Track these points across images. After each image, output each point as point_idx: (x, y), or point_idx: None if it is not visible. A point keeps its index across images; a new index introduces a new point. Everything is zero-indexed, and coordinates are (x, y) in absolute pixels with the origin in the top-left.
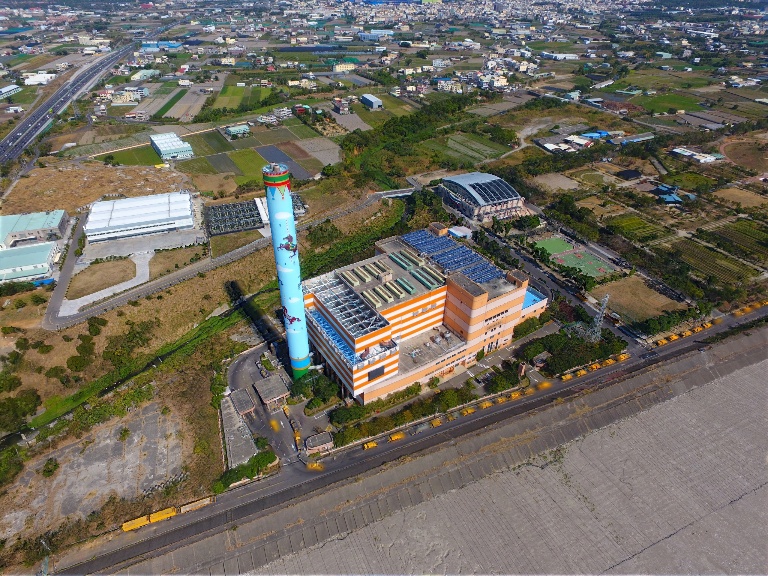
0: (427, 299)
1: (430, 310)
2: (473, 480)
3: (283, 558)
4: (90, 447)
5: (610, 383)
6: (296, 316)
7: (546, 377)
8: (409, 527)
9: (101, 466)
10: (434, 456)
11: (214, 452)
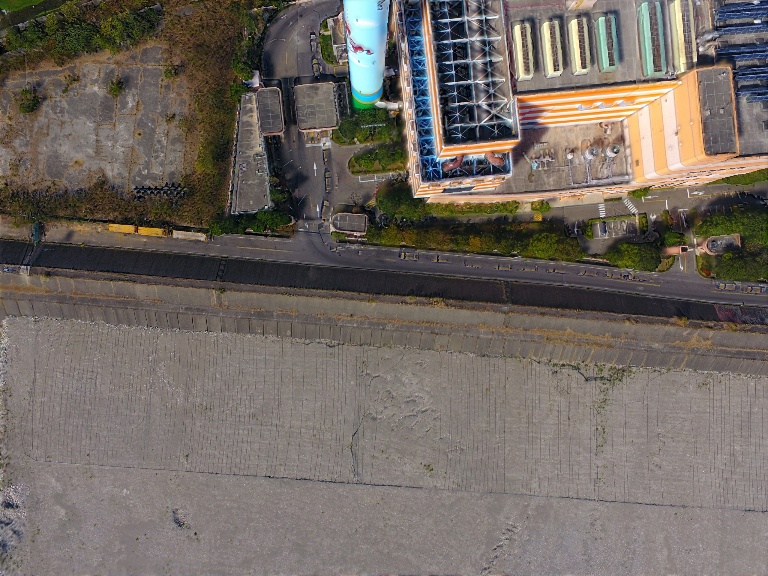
0: (623, 93)
1: (615, 105)
2: (501, 354)
3: (266, 336)
4: (74, 88)
5: None
6: (365, 46)
7: (700, 270)
8: (403, 368)
9: (88, 126)
10: (473, 314)
11: (221, 173)
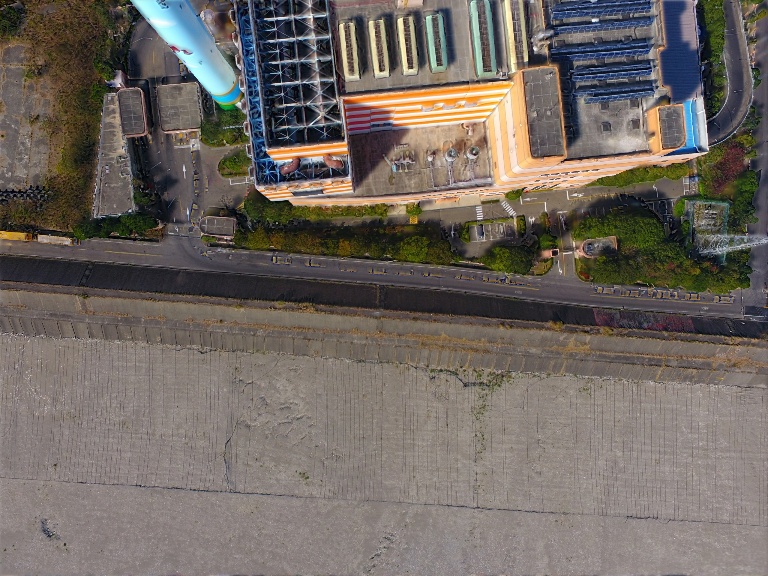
0: (459, 94)
1: (462, 106)
2: (377, 360)
3: (136, 342)
4: None
5: (651, 334)
6: (179, 46)
7: (578, 274)
8: (277, 374)
9: None
10: (344, 319)
11: (86, 176)
